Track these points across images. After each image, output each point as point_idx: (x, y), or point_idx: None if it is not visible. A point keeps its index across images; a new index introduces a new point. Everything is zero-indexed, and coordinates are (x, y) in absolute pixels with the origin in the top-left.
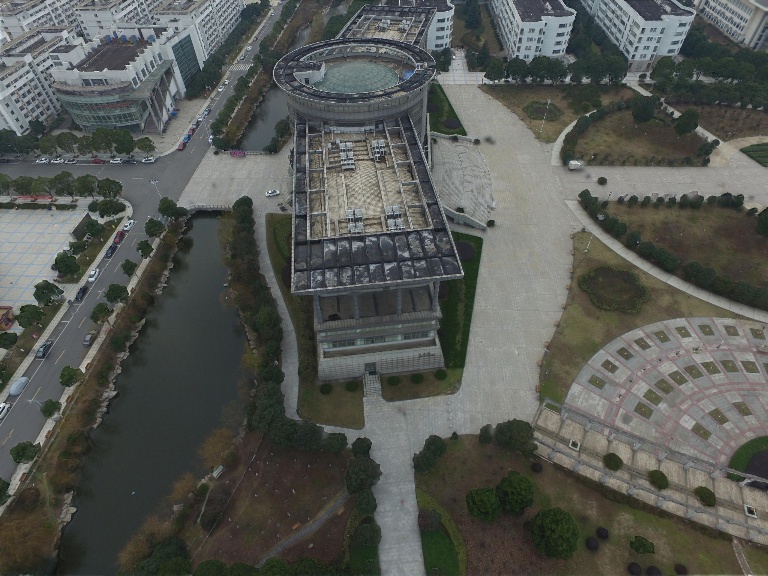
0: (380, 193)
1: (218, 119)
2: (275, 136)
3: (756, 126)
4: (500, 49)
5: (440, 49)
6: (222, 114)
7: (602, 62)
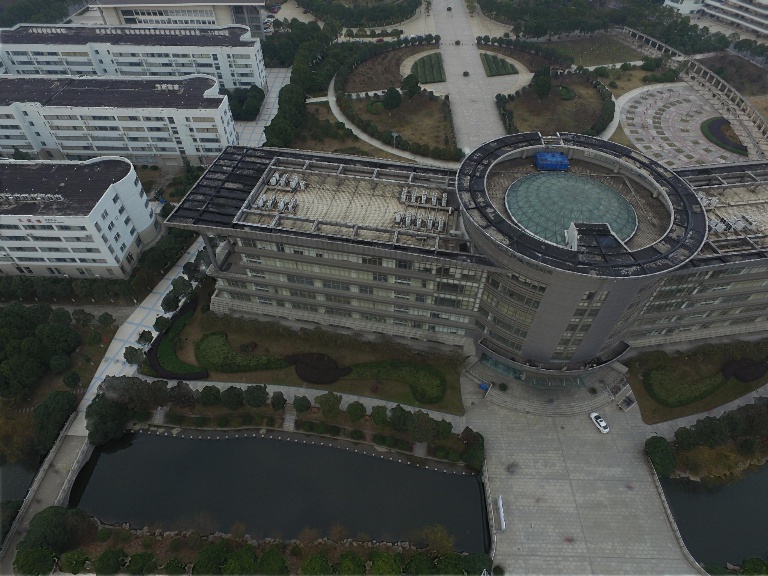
0: (767, 203)
1: (427, 570)
2: (402, 463)
3: (389, 70)
4: (154, 169)
5: (153, 216)
6: (395, 570)
7: (296, 95)
